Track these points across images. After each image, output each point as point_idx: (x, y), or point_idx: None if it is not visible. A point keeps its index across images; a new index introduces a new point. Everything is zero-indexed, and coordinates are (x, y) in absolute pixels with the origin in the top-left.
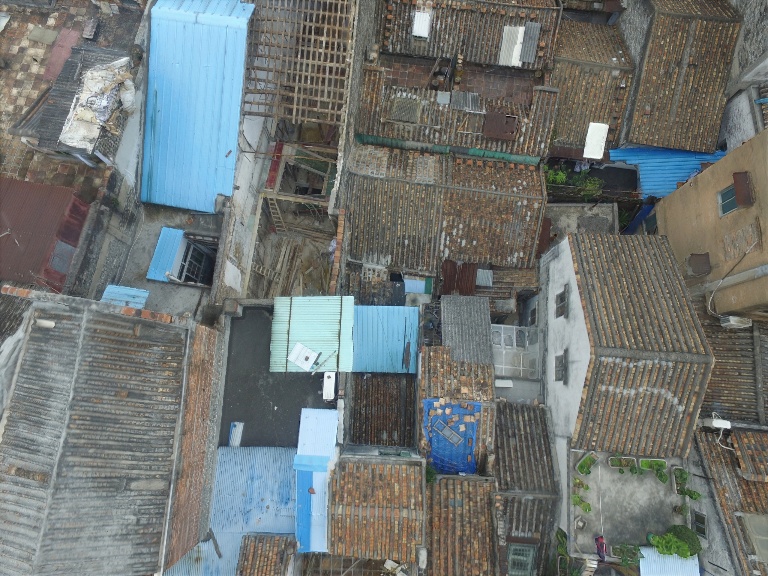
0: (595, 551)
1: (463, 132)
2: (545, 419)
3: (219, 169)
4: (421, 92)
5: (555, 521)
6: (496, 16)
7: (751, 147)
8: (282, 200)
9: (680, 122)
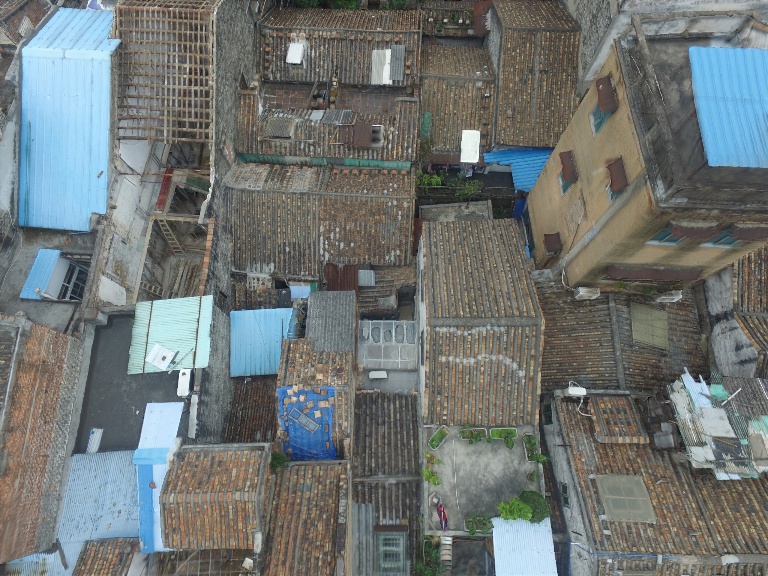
0: (450, 527)
1: (335, 144)
2: (416, 405)
3: (92, 189)
4: (298, 112)
5: (421, 505)
6: (364, 42)
7: (571, 128)
8: (172, 221)
9: (541, 122)
